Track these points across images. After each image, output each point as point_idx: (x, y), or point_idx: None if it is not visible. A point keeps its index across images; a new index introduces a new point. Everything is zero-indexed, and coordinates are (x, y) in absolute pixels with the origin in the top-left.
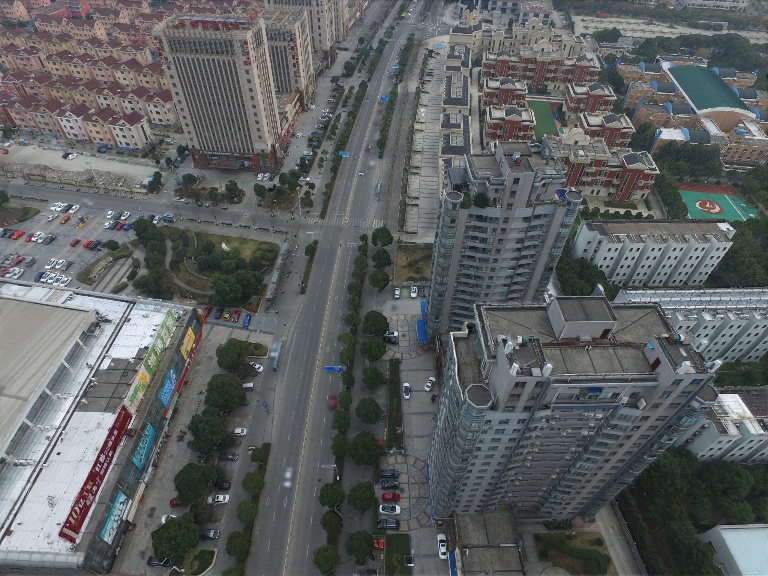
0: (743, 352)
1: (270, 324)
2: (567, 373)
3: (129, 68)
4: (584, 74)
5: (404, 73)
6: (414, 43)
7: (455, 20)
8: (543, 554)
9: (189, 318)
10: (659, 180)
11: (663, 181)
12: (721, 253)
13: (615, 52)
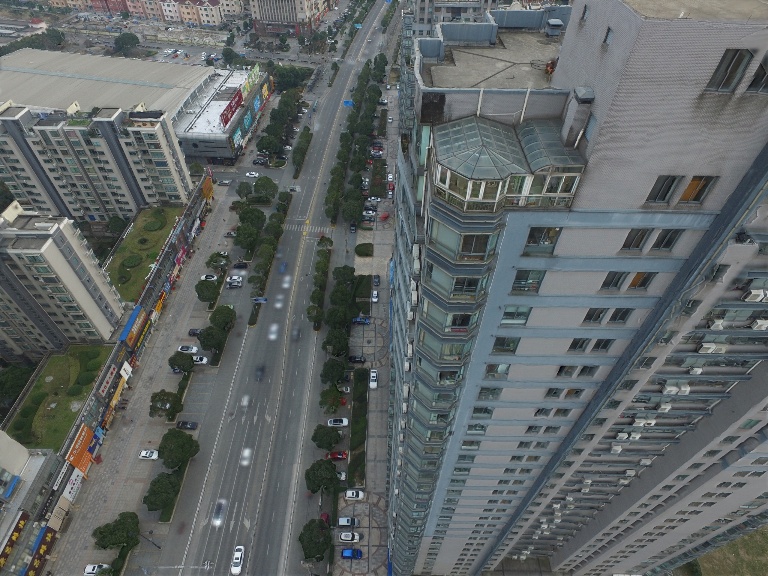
0: None
1: (310, 97)
2: None
3: None
4: None
5: None
6: None
7: None
8: None
9: (266, 77)
10: None
11: None
12: None
13: None
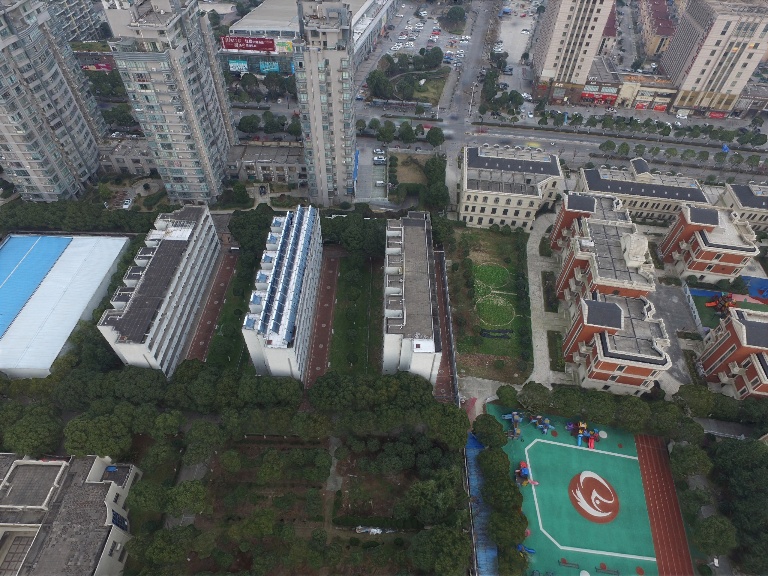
0: None
1: None
2: (144, 3)
3: (653, 16)
4: None
5: None
6: None
7: None
8: None
9: None
10: (621, 397)
11: (617, 400)
12: None
13: None
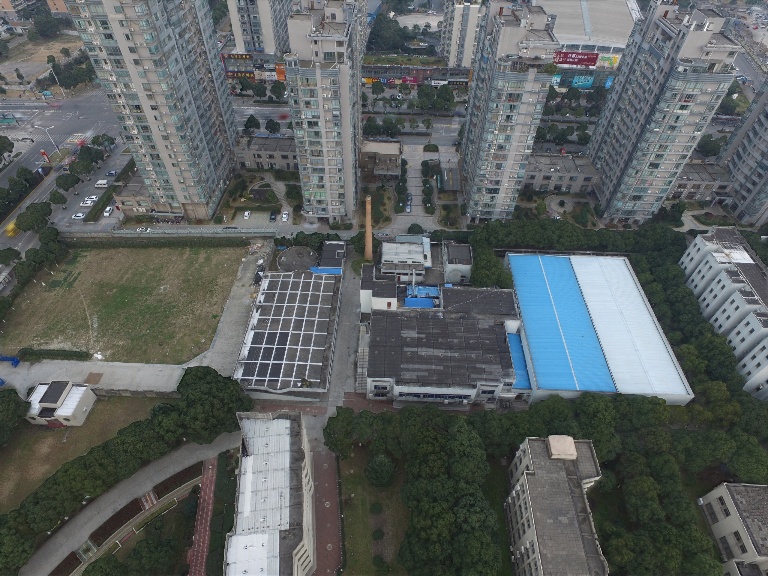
0: None
1: None
2: None
3: None
4: None
5: None
6: None
7: None
8: (578, 202)
9: None
10: None
11: None
12: None
13: None
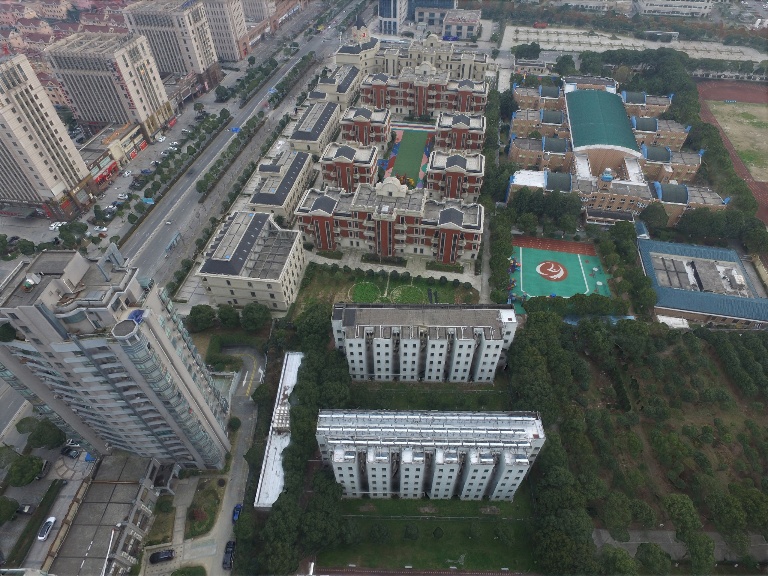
0: (484, 492)
1: None
2: None
3: None
4: (468, 100)
5: (286, 97)
6: (316, 61)
7: (375, 33)
8: None
9: None
10: (493, 238)
11: (497, 239)
12: (495, 351)
13: (533, 70)
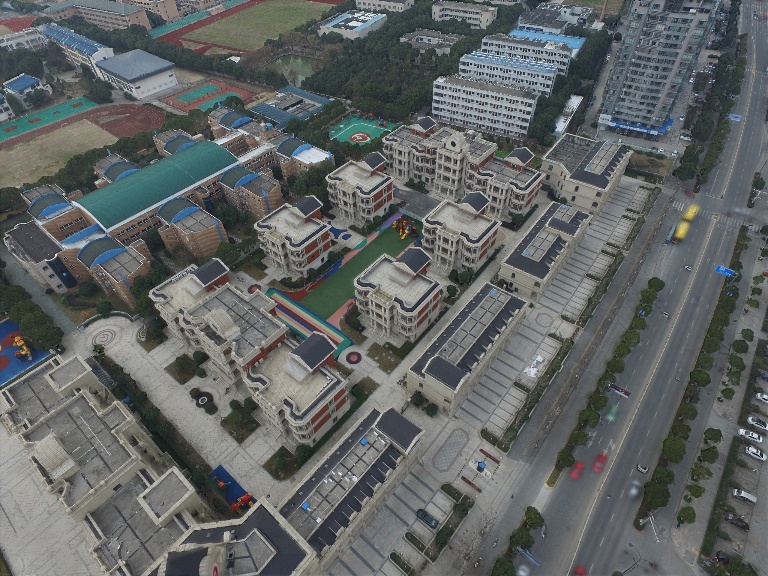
0: None
1: None
2: None
3: None
4: None
5: None
6: None
7: None
8: None
9: None
10: None
11: None
12: None
13: None
